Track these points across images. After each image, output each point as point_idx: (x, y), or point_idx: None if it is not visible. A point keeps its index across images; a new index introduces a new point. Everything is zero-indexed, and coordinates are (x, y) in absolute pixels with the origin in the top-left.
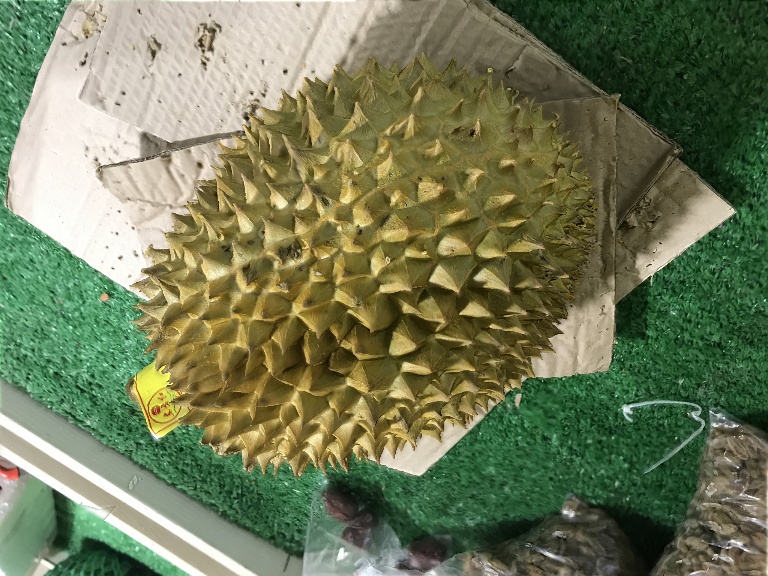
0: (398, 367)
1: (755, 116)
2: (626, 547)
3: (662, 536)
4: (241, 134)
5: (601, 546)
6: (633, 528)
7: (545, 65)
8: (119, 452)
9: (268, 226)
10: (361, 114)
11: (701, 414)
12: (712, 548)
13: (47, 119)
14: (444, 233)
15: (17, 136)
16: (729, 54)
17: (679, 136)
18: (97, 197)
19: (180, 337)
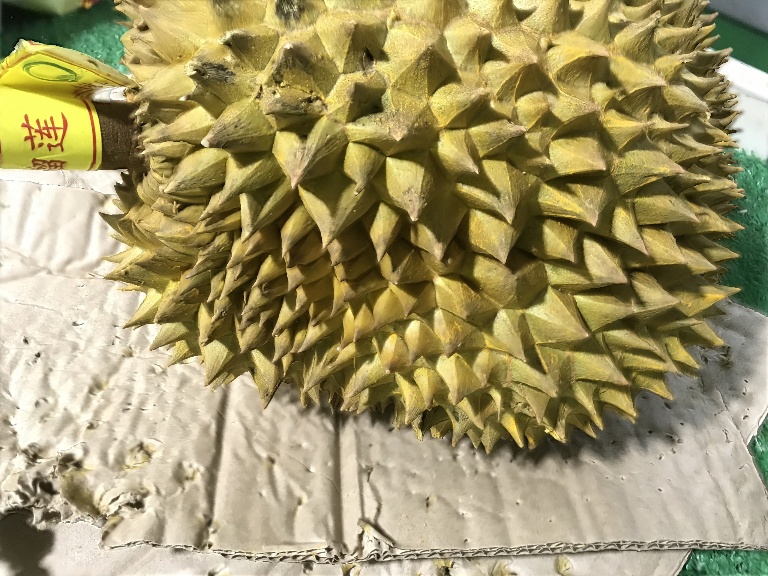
0: None
1: (764, 278)
2: None
3: None
4: None
5: None
6: None
7: None
8: None
9: None
10: None
11: None
12: None
13: None
14: None
15: None
16: None
17: None
18: None
19: None
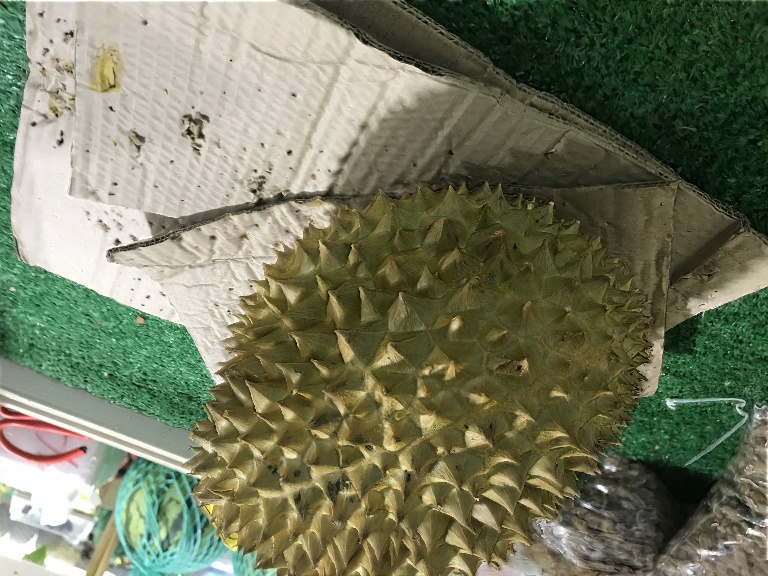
0: (455, 551)
1: None
2: (664, 497)
3: (698, 483)
4: (251, 205)
5: (641, 500)
6: (671, 475)
7: (592, 148)
8: (185, 429)
9: (313, 467)
10: (395, 353)
11: (745, 406)
12: (746, 523)
13: (38, 190)
14: (495, 472)
15: (11, 203)
16: None
17: (746, 197)
18: None
19: (244, 541)
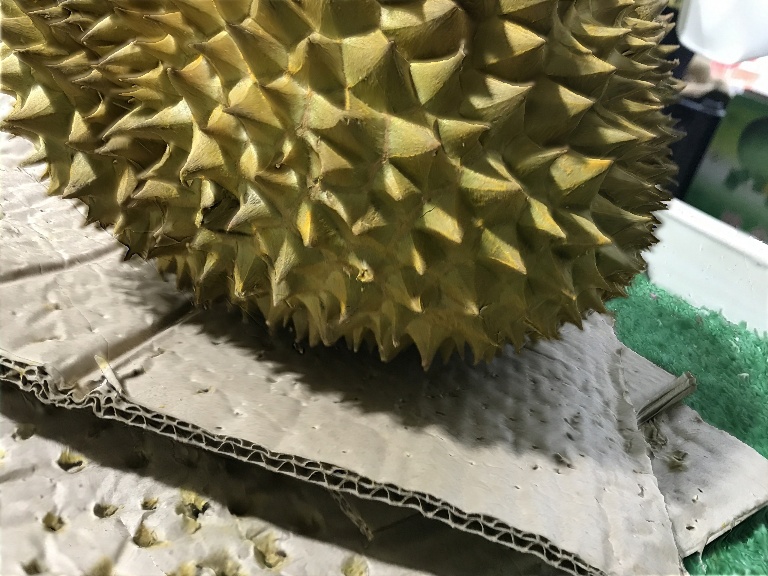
0: None
1: (757, 431)
2: None
3: None
4: None
5: None
6: None
7: None
8: None
9: None
10: None
11: None
12: None
13: None
14: None
15: None
16: (704, 380)
17: None
18: None
19: None
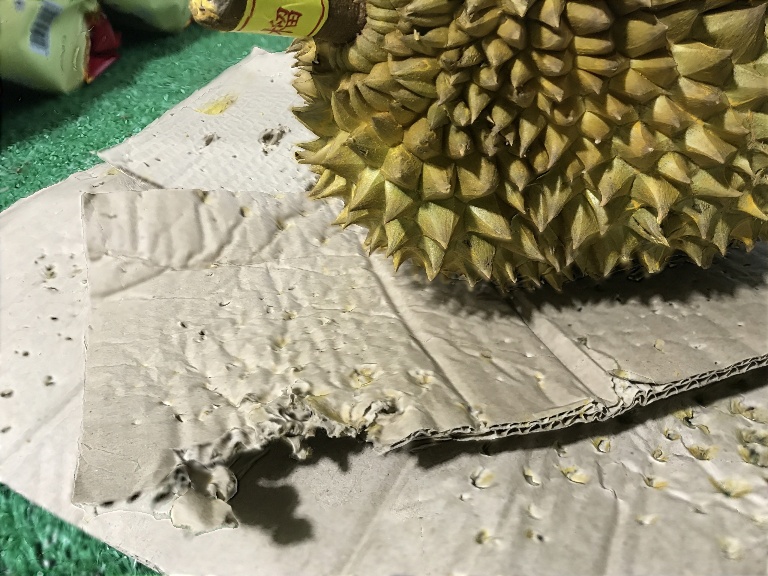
0: None
1: None
2: None
3: None
4: None
5: None
6: None
7: None
8: None
9: None
10: None
11: None
12: None
13: None
14: None
15: None
16: None
17: None
18: (19, 309)
19: None
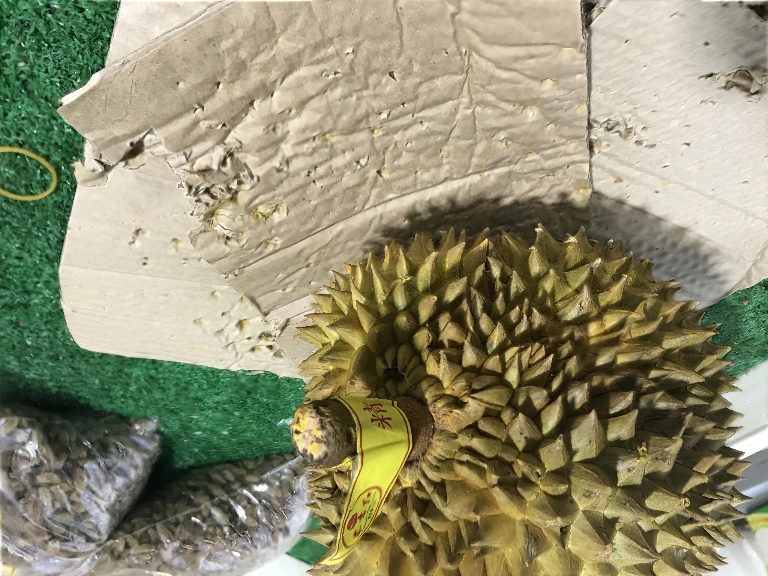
0: None
1: None
2: None
3: (166, 466)
4: None
5: None
6: None
7: None
8: None
9: (697, 572)
10: None
11: None
12: (230, 528)
13: None
14: None
15: None
16: None
17: None
18: None
19: None
